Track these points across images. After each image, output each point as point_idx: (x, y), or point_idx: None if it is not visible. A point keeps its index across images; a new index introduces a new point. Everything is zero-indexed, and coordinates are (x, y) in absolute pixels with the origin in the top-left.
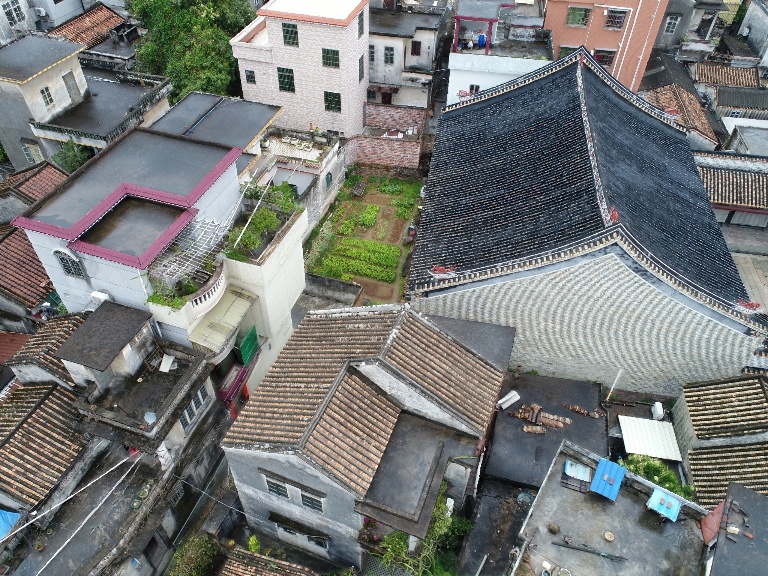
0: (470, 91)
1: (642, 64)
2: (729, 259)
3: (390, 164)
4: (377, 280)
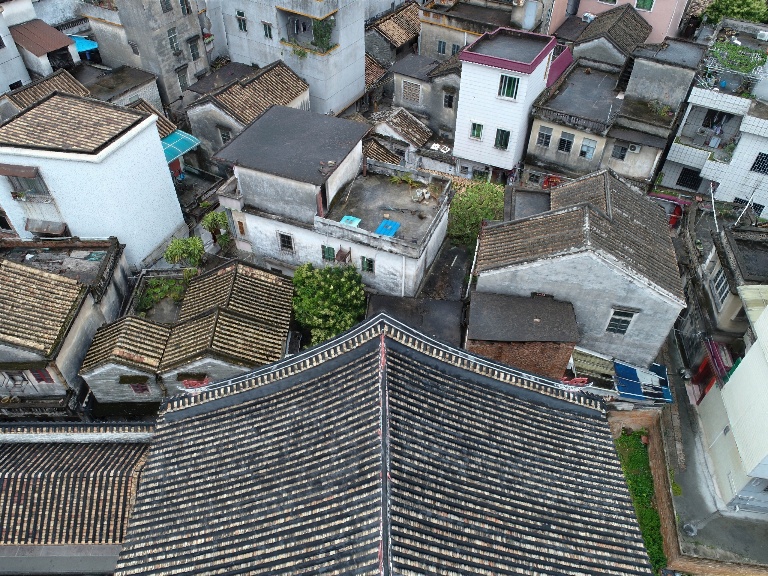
0: None
1: None
2: None
3: None
4: None
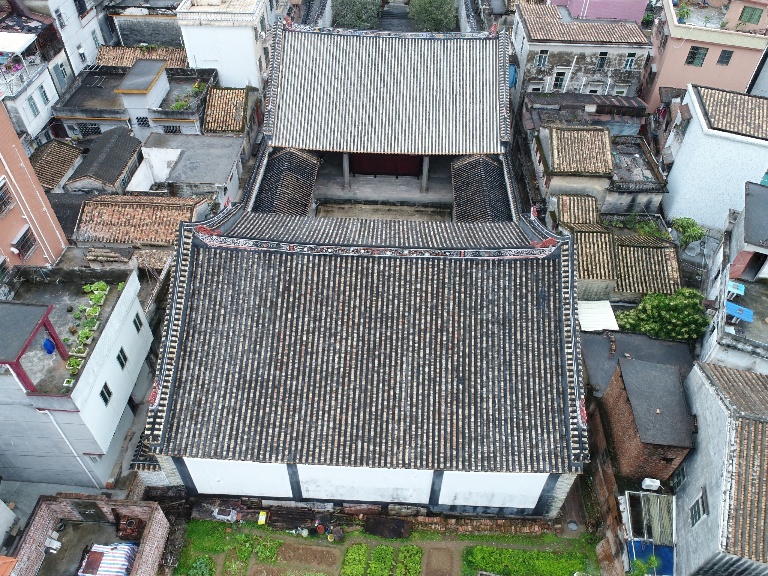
0: (103, 400)
1: (50, 213)
2: None
3: (154, 573)
4: (420, 572)
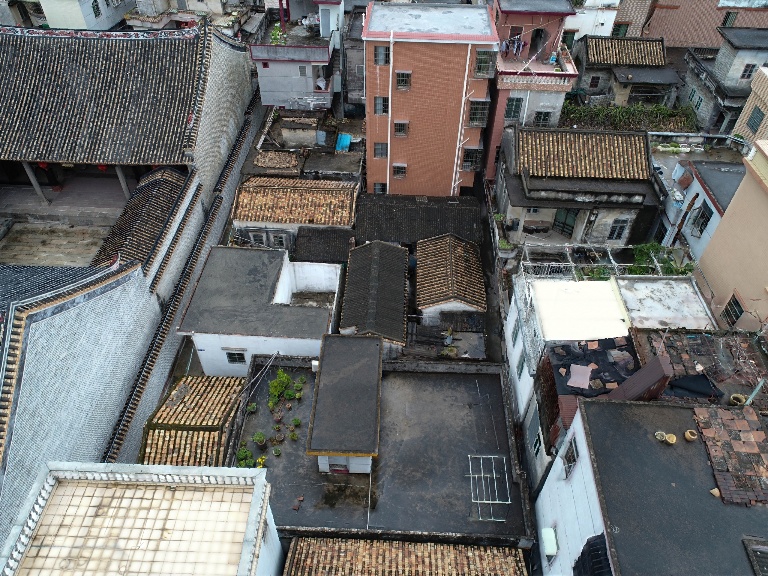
0: None
1: None
2: (8, 155)
3: None
4: None
